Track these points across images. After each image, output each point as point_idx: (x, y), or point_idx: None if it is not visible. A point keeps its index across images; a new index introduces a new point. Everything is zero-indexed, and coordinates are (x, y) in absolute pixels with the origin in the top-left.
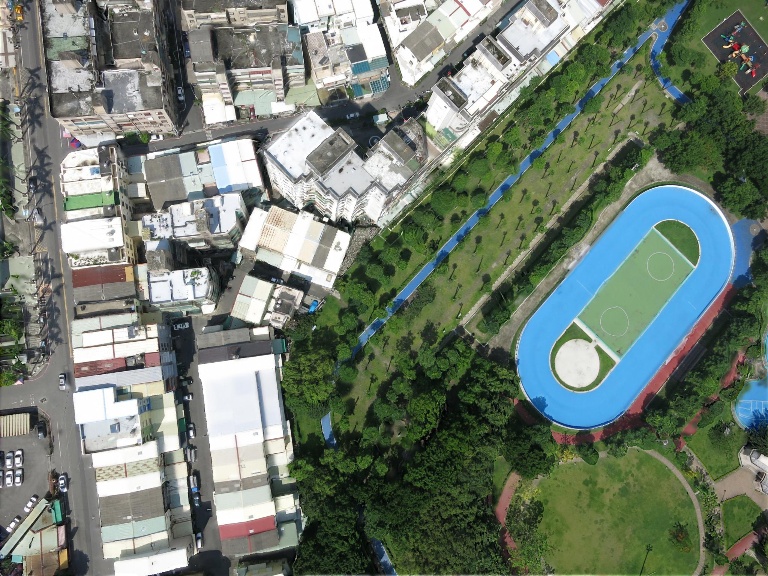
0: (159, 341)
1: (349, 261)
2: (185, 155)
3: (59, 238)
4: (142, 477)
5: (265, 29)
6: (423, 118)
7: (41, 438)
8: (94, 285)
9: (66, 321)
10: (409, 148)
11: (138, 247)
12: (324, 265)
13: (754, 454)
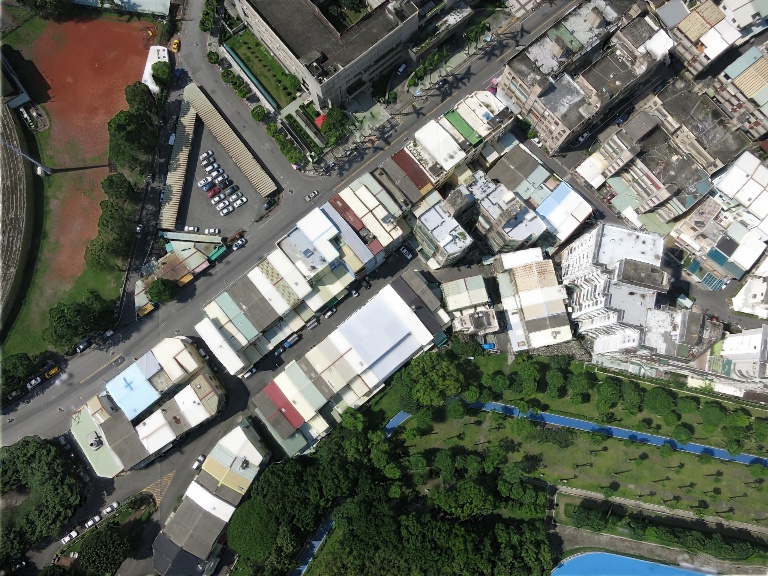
0: (391, 243)
1: (545, 352)
2: (543, 170)
3: (415, 125)
4: (279, 297)
5: (691, 162)
6: (723, 335)
7: (263, 208)
8: (402, 170)
9: (358, 169)
10: (697, 338)
11: (447, 183)
12: (532, 332)
13: None
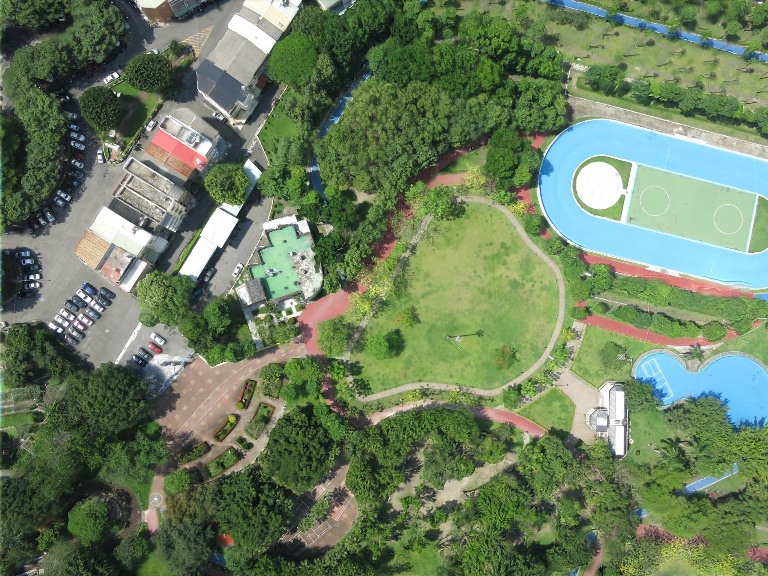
0: None
1: None
2: None
3: None
4: None
5: None
6: None
7: None
8: None
9: None
10: None
11: None
12: None
13: (619, 387)
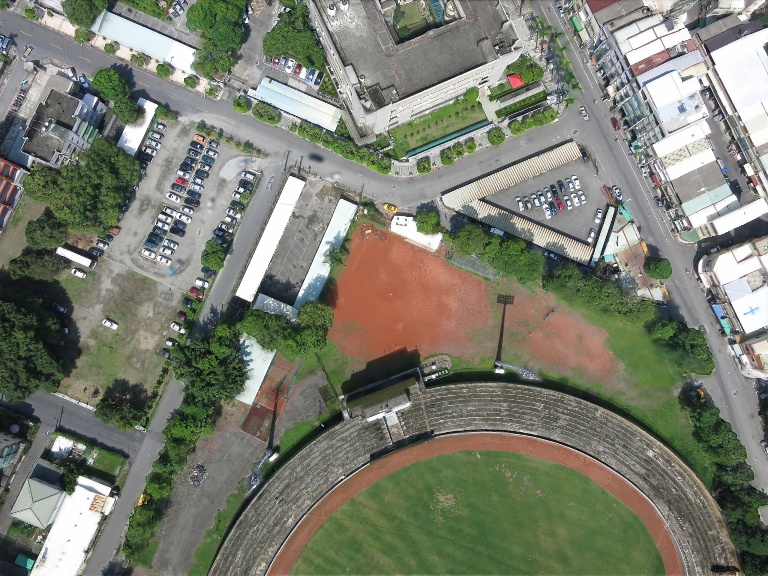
0: None
1: None
2: None
3: None
4: (701, 154)
5: None
6: None
7: (587, 161)
8: (611, 5)
9: None
10: None
11: None
12: None
13: None
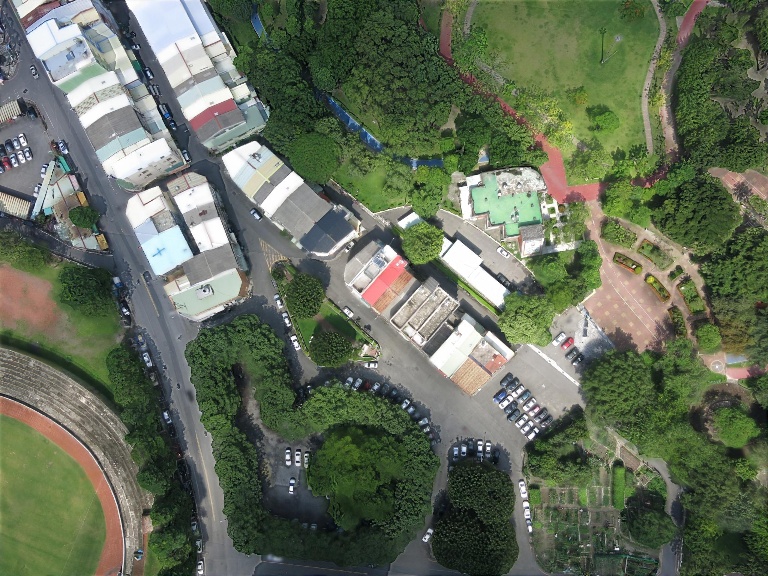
0: None
1: None
2: None
3: None
4: (112, 100)
5: None
6: None
7: (34, 119)
8: None
9: (20, 25)
10: None
11: None
12: None
13: None
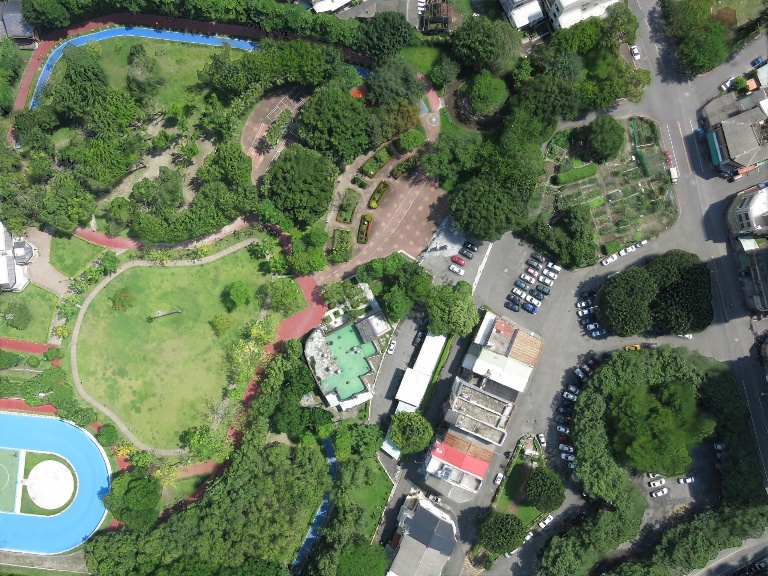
0: None
1: None
2: None
3: None
4: None
5: None
6: None
7: None
8: None
9: None
10: None
11: None
12: None
13: (6, 288)
